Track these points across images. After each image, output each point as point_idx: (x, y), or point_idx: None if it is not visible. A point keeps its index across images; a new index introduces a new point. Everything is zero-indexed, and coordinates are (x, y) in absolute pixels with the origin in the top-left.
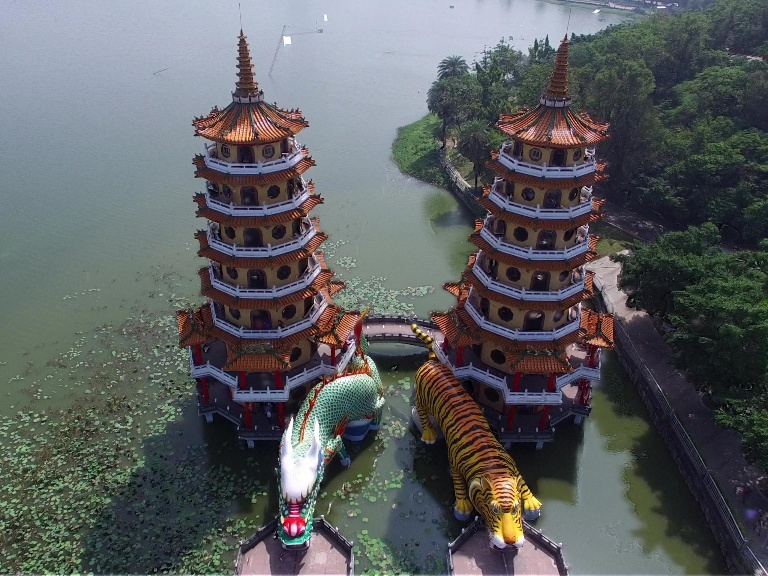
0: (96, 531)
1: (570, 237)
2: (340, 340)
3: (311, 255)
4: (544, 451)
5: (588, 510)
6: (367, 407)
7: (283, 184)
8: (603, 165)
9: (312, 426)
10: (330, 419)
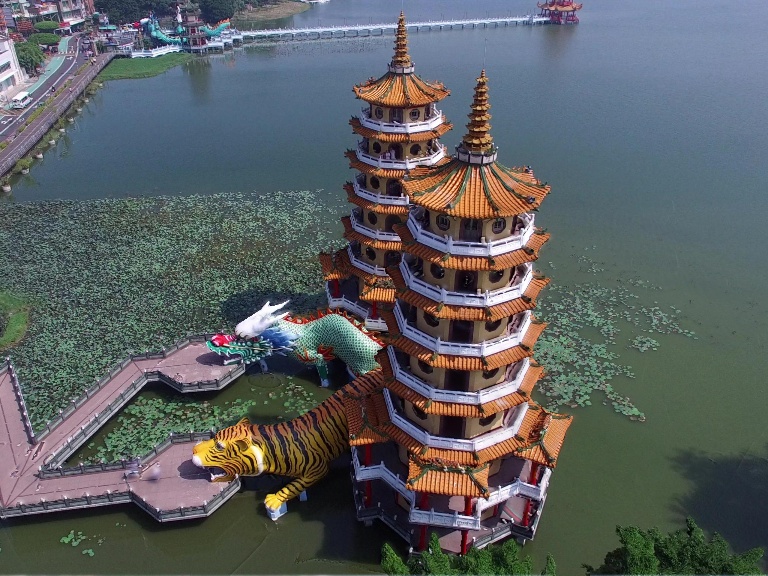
0: (256, 293)
1: (436, 324)
2: (363, 293)
3: (373, 211)
4: (369, 533)
5: (292, 574)
6: (353, 361)
7: (383, 145)
8: (488, 266)
9: (308, 326)
10: (321, 336)
